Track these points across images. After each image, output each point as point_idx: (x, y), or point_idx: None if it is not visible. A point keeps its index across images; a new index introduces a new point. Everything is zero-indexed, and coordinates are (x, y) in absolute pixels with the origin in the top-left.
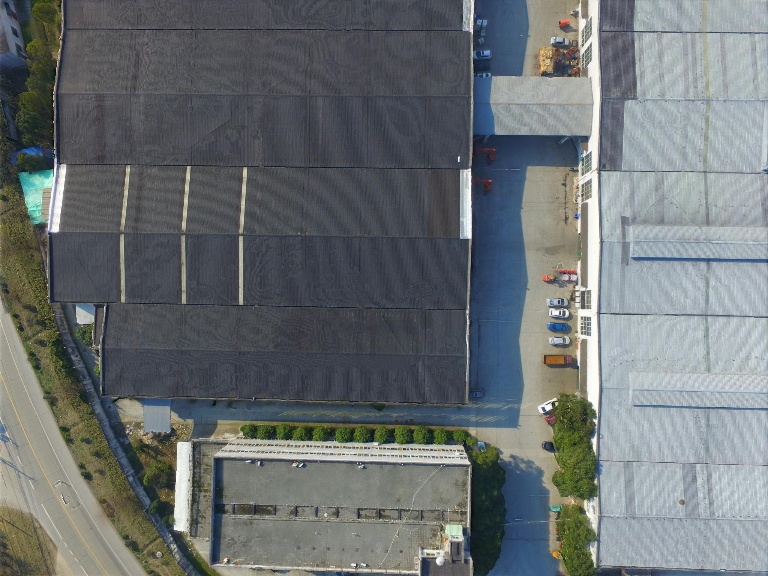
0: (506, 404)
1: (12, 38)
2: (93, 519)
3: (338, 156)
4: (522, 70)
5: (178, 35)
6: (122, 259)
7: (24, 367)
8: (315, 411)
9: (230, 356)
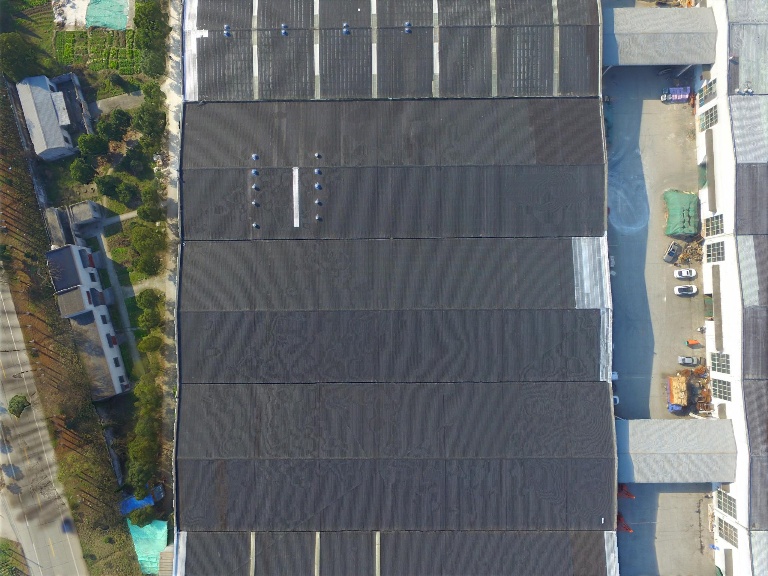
0: None
1: (116, 373)
2: None
3: (476, 519)
4: (649, 390)
5: (301, 389)
6: None
7: None
8: None
9: None
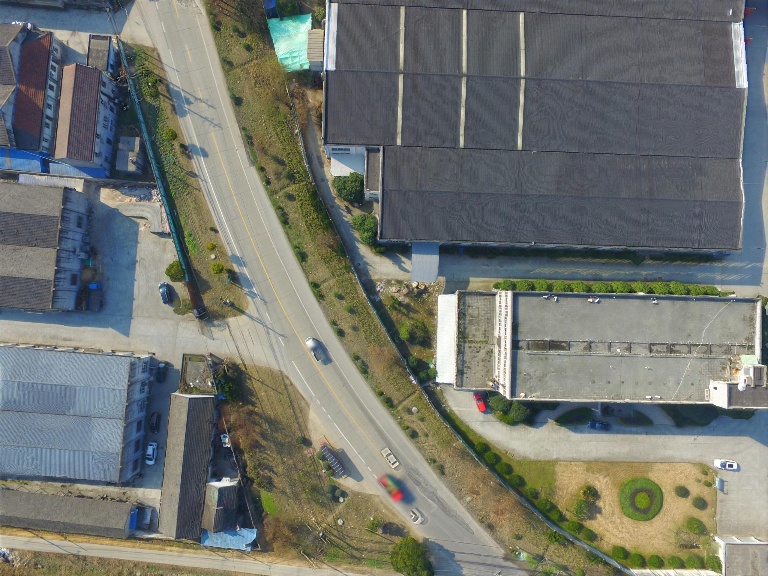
0: (749, 263)
1: None
2: (346, 376)
3: (614, 5)
4: None
5: None
6: (400, 100)
7: (271, 222)
8: (567, 269)
9: (514, 198)
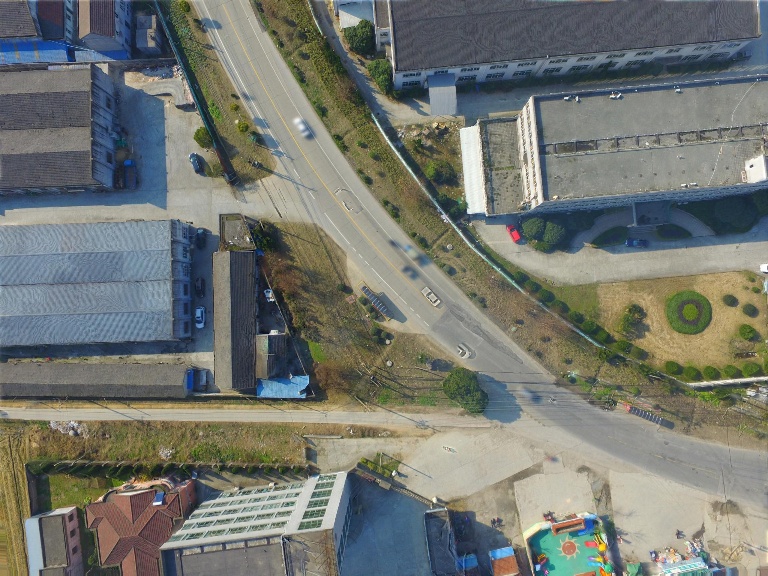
0: None
1: None
2: (378, 222)
3: None
4: None
5: None
6: None
7: (288, 82)
8: None
9: None
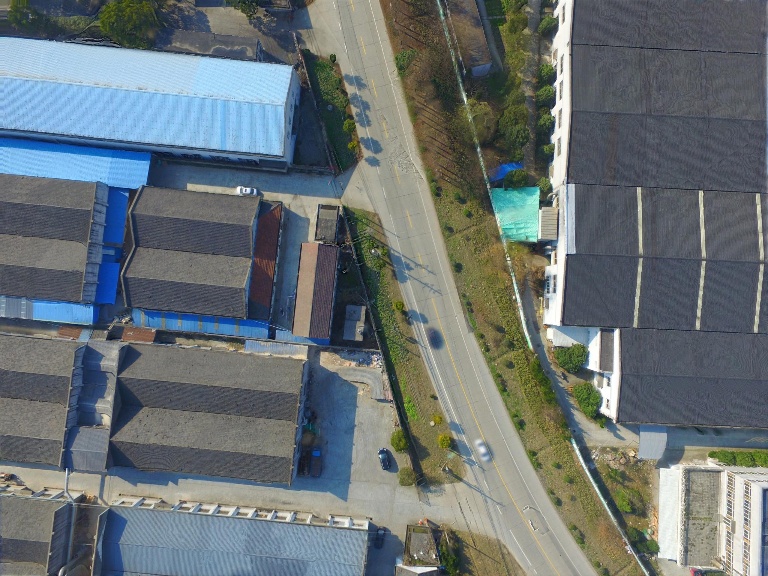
0: None
1: None
2: (562, 545)
3: None
4: None
5: (687, 56)
6: (638, 283)
7: (489, 389)
8: None
9: (755, 385)
